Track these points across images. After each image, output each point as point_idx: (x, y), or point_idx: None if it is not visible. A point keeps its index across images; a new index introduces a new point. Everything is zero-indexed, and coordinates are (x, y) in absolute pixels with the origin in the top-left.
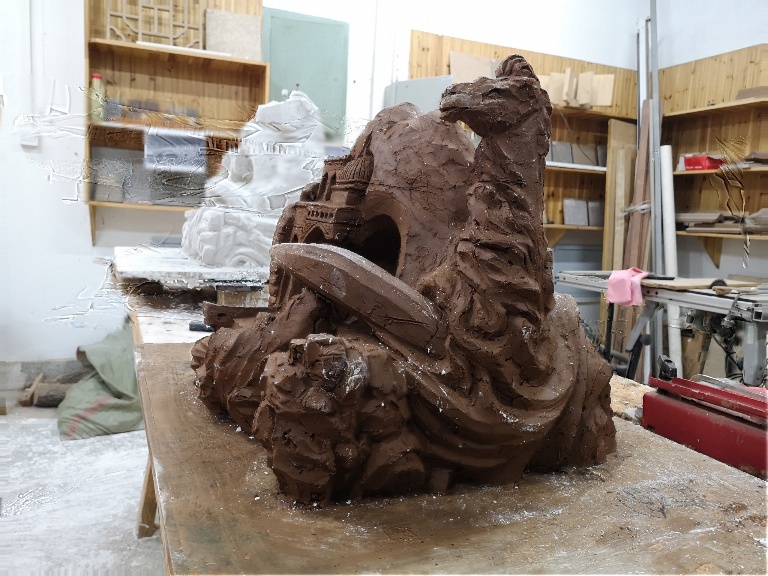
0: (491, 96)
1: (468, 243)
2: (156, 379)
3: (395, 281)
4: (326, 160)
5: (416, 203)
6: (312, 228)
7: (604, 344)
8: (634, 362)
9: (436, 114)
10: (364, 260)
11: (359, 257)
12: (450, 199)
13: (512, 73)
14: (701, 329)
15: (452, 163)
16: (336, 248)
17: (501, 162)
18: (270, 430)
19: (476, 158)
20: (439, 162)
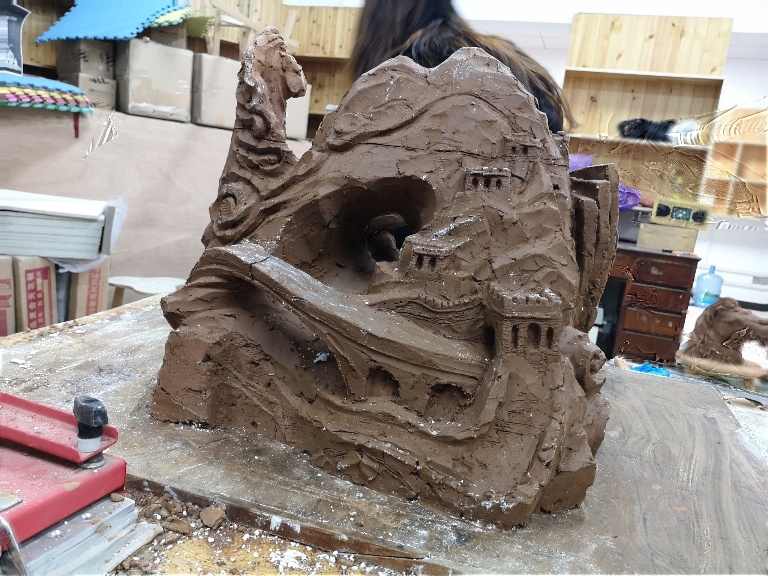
0: None
1: None
2: None
3: None
4: None
5: None
6: None
7: None
8: None
9: None
10: None
11: None
12: None
13: None
14: None
15: None
16: None
17: None
18: None
19: None
20: None
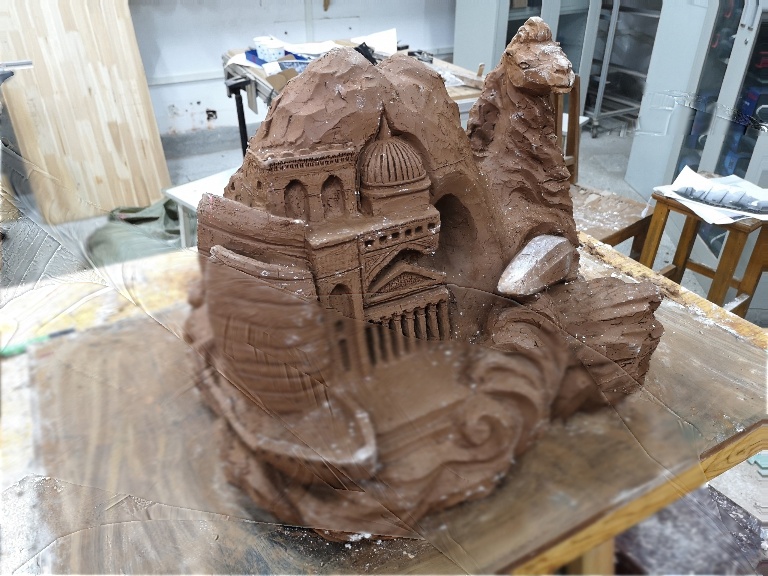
0: None
1: (552, 182)
2: None
3: None
4: (276, 162)
5: None
6: (391, 257)
7: None
8: None
9: (421, 66)
10: None
11: None
12: None
13: None
14: None
15: None
16: (548, 242)
17: None
18: None
19: None
20: None
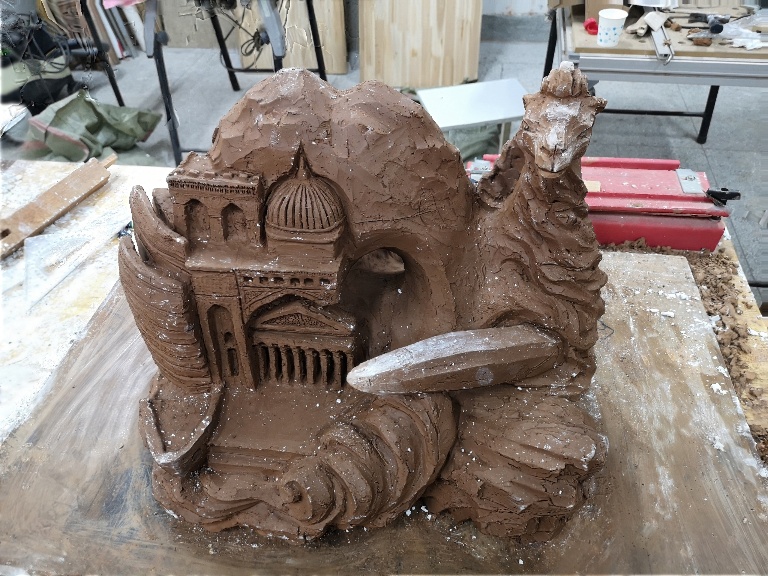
0: (583, 135)
1: (556, 268)
2: (136, 569)
3: (516, 336)
4: (175, 180)
5: (433, 227)
6: (273, 297)
7: (95, 46)
8: (160, 66)
9: (391, 100)
10: (483, 337)
11: (477, 337)
12: (458, 205)
13: (581, 94)
14: (208, 8)
15: (444, 163)
16: (455, 345)
17: (575, 187)
18: (536, 526)
19: (547, 188)
20: (434, 169)
